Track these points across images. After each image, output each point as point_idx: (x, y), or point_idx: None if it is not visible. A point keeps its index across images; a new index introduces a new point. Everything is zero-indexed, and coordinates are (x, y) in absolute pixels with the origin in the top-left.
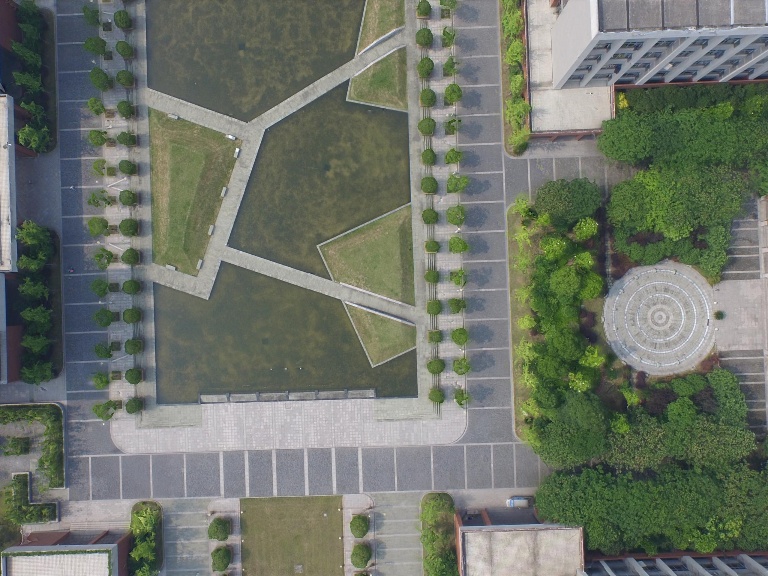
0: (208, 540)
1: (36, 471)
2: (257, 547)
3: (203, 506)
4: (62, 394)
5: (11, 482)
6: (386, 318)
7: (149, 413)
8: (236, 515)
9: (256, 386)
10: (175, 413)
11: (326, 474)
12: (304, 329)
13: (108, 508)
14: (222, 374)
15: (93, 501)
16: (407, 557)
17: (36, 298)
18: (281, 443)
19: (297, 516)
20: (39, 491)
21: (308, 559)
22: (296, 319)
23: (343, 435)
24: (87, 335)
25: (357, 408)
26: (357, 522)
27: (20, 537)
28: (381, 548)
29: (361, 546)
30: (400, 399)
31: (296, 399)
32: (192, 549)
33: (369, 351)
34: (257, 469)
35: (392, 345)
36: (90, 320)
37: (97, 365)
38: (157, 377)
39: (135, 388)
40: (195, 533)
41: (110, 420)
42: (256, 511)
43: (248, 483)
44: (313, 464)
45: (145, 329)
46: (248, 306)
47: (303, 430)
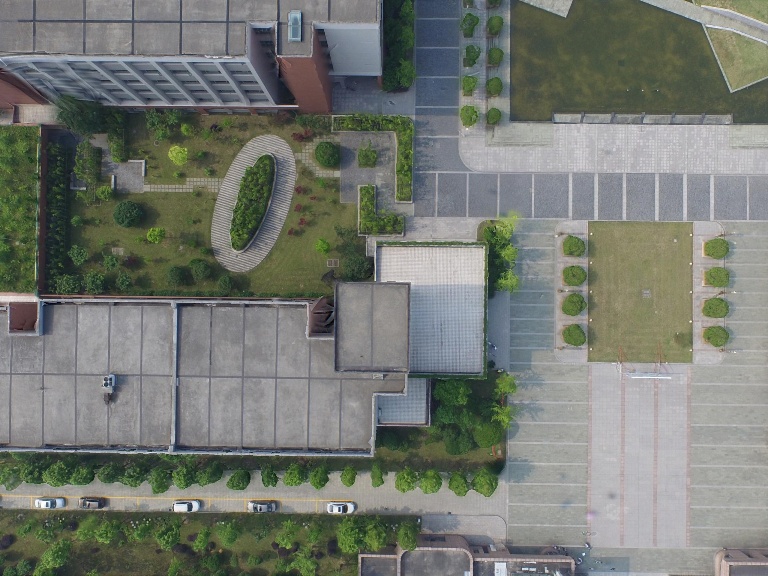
0: (554, 262)
1: (381, 185)
2: (605, 270)
3: (550, 227)
4: (410, 109)
5: (356, 195)
6: (752, 40)
7: (502, 129)
8: (584, 237)
9: (611, 107)
10: (527, 131)
11: (677, 200)
12: (661, 52)
13: (453, 225)
14: (576, 94)
15: (438, 218)
16: (756, 287)
17: (397, 4)
18: (633, 167)
19: (647, 240)
20: (384, 205)
21: (657, 284)
22: (654, 42)
23: (696, 161)
24: (438, 50)
25: (712, 134)
26: (720, 240)
27: (364, 250)
28: (730, 277)
29: (719, 267)
30: (757, 126)
31: (650, 123)
32: (538, 270)
33: (729, 75)
34: (607, 192)
35: (755, 68)
36: (442, 35)
37: (447, 81)
38: (511, 94)
39: (486, 105)
40: (541, 254)
41: (459, 137)
42: (605, 234)
43: (597, 206)
44: (664, 189)
45: (501, 44)
46: (605, 27)
47: (656, 154)
